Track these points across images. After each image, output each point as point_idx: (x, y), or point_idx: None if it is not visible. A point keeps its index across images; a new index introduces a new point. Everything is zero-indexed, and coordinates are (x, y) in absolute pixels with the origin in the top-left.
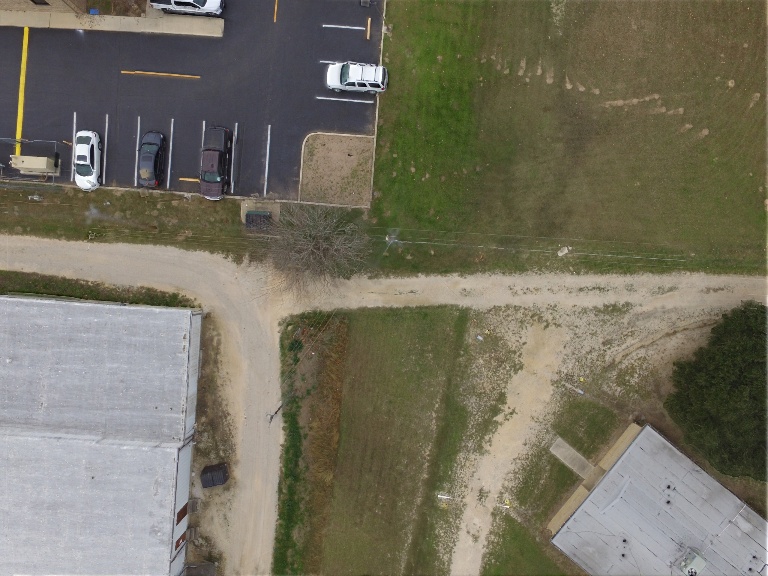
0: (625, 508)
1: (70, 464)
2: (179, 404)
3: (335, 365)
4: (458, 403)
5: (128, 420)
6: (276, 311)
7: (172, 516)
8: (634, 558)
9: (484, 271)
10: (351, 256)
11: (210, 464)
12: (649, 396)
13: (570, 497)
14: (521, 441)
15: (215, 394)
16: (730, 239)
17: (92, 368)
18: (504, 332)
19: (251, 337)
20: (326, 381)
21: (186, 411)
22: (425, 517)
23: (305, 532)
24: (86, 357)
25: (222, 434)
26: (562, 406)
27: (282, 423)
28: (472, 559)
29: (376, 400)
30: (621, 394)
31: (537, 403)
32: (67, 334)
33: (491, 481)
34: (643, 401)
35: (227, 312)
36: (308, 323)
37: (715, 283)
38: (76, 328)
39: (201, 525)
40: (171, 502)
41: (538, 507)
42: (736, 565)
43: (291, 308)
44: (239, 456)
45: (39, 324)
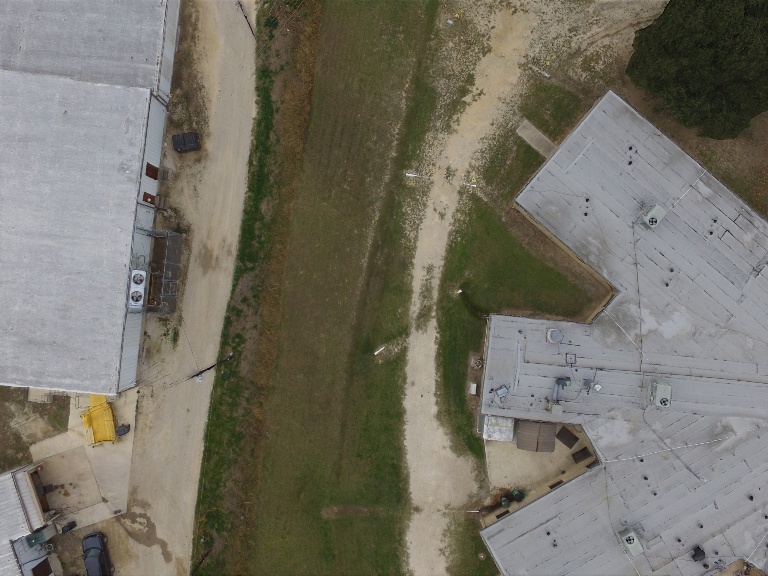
0: (588, 165)
1: (44, 97)
2: (154, 56)
3: (309, 41)
4: (428, 84)
5: (104, 68)
6: None
7: (141, 155)
8: (597, 219)
9: None
10: None
11: None
12: (613, 82)
13: None
14: (488, 121)
15: (191, 67)
16: None
17: (71, 16)
18: (473, 16)
19: (228, 14)
20: (299, 55)
21: (161, 65)
22: (393, 195)
23: (273, 204)
24: (66, 5)
25: (196, 106)
26: (529, 88)
27: (255, 96)
28: (438, 236)
29: (348, 77)
30: (586, 80)
31: (504, 85)
32: None
33: (458, 160)
34: (608, 87)
35: None
36: (284, 1)
37: None
38: None
39: (171, 196)
40: (141, 140)
41: (504, 188)
42: (697, 229)
43: None
44: (212, 128)
45: None
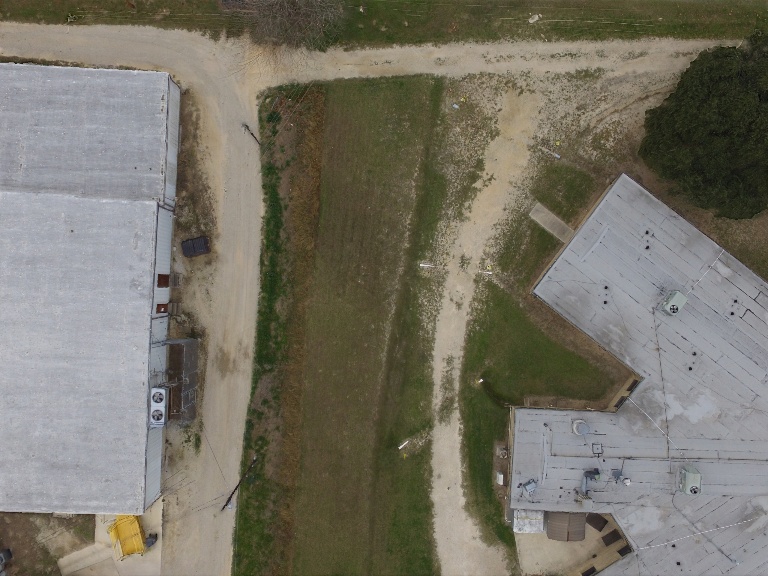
0: (605, 253)
1: (49, 218)
2: (158, 164)
3: (314, 135)
4: (437, 172)
5: (107, 181)
6: (254, 85)
7: (152, 270)
8: (616, 306)
9: (457, 40)
10: (325, 8)
11: (191, 238)
12: (625, 159)
13: (551, 260)
14: (500, 206)
15: (195, 168)
16: (696, 4)
17: (71, 129)
18: (479, 99)
19: (230, 111)
20: (305, 150)
21: (165, 173)
22: (408, 287)
23: (288, 304)
24: (65, 118)
25: (203, 208)
26: (540, 171)
27: (262, 195)
28: (456, 327)
29: (355, 170)
30: (597, 158)
31: (515, 168)
32: (46, 96)
33: (472, 247)
34: (619, 164)
35: (206, 88)
36: (286, 95)
37: (684, 48)
38: (55, 90)
39: (183, 301)
40: (151, 255)
41: (520, 273)
42: (718, 310)
43: (269, 81)
44: (220, 230)
45: (18, 87)
